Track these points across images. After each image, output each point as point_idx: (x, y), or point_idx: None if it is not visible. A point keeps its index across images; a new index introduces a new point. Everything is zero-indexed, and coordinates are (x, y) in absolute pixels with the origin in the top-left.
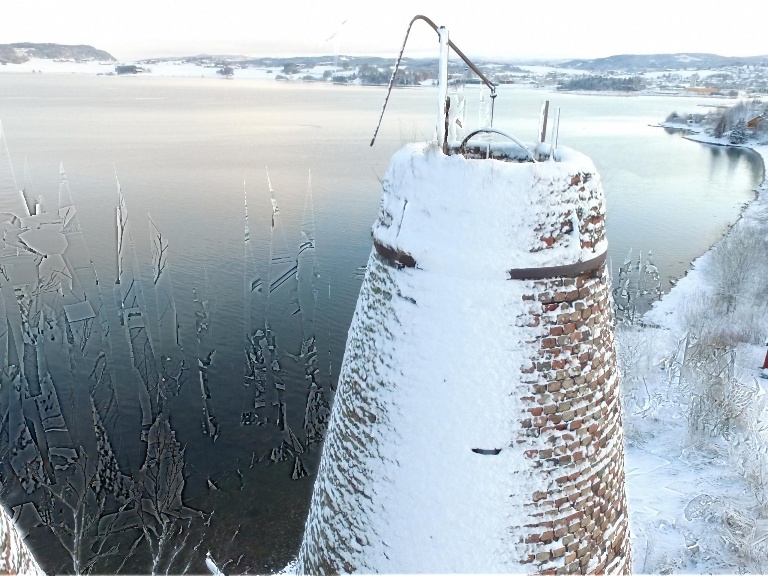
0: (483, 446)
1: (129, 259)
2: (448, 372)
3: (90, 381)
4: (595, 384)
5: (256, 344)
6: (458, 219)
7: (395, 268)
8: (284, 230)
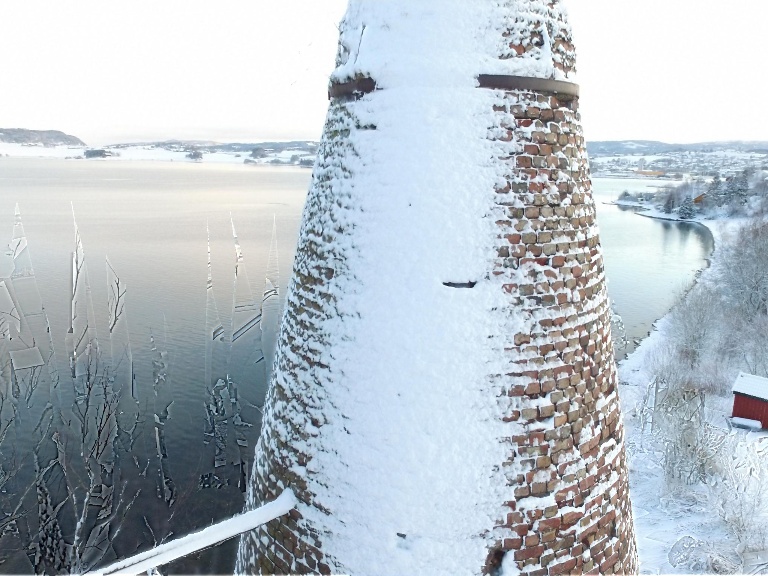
0: (455, 278)
1: (84, 303)
2: (413, 193)
3: (34, 436)
4: (576, 222)
5: (217, 394)
6: (420, 23)
7: (353, 101)
8: (248, 277)
